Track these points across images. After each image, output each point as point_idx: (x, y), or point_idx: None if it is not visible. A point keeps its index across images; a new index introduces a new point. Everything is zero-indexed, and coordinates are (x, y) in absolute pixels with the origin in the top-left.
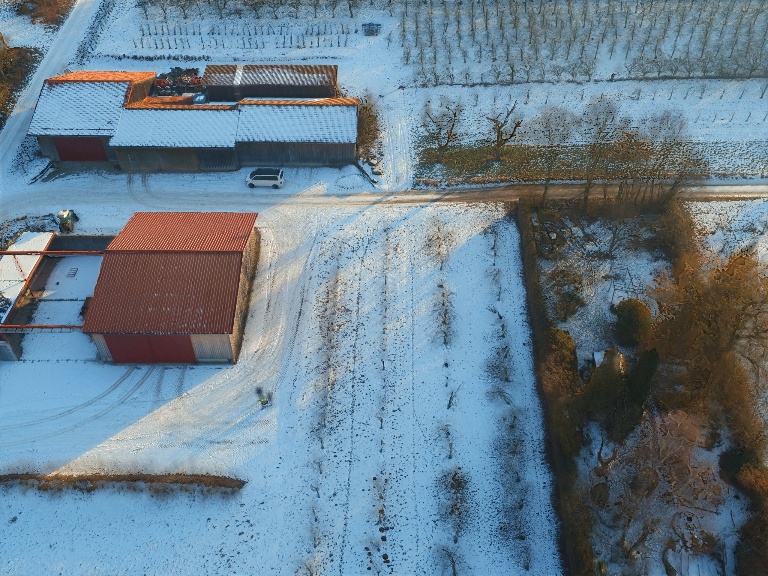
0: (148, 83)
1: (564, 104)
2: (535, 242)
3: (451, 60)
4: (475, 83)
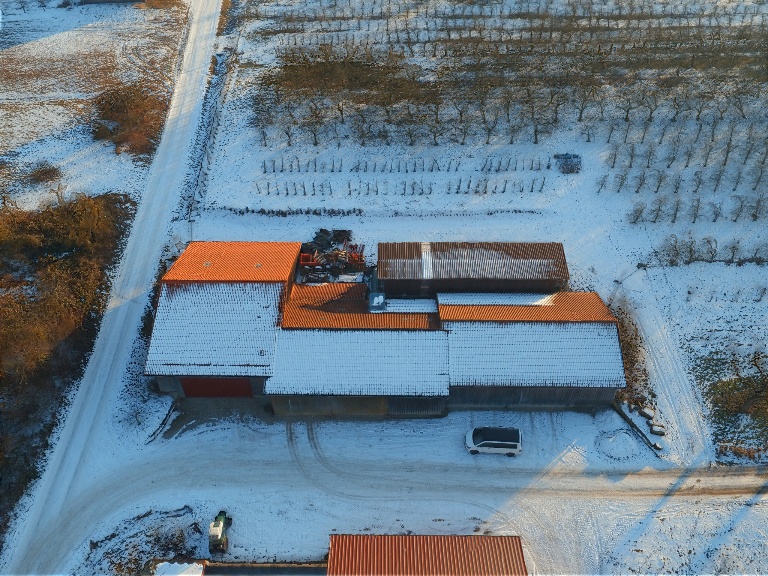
0: (293, 264)
1: None
2: None
3: (699, 220)
4: (742, 258)
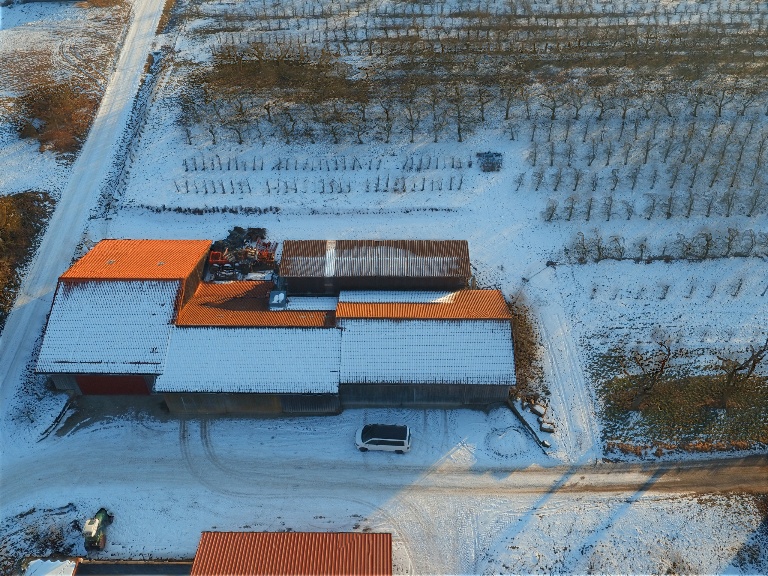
0: (201, 262)
1: None
2: None
3: (612, 218)
4: (652, 256)
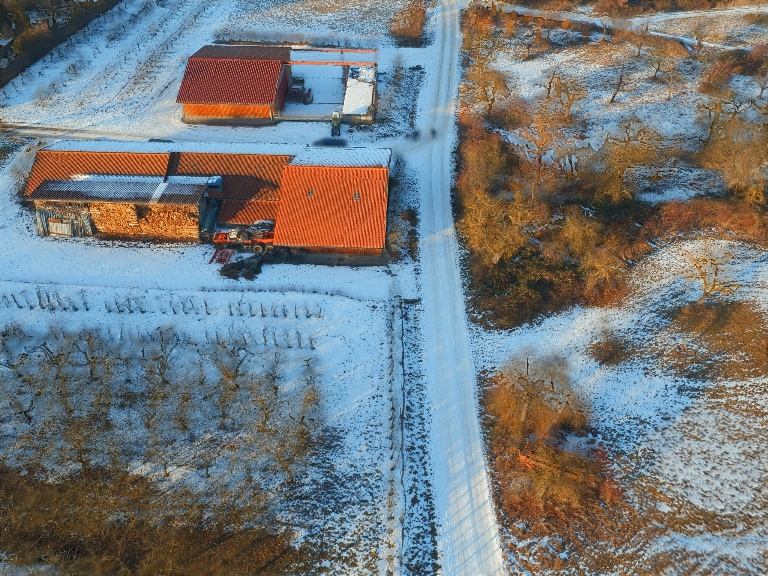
0: None
1: None
2: None
3: None
4: None
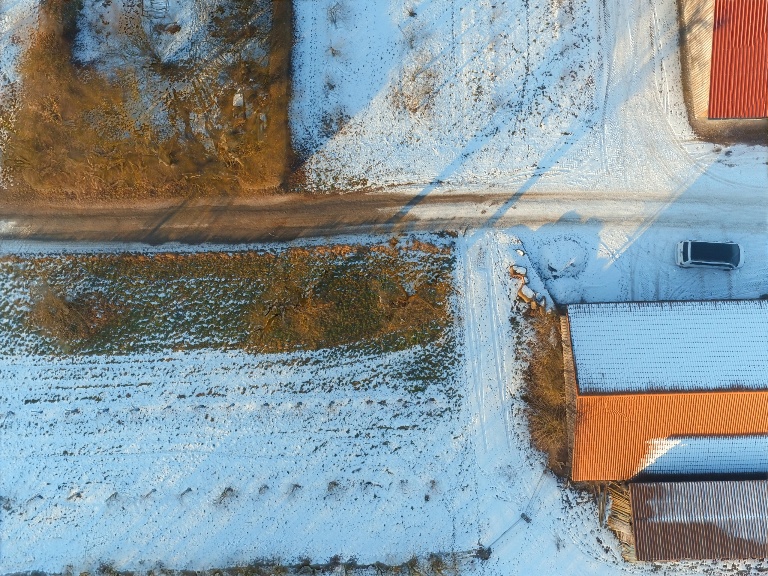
0: None
1: (153, 485)
2: (269, 74)
3: None
4: (328, 573)
